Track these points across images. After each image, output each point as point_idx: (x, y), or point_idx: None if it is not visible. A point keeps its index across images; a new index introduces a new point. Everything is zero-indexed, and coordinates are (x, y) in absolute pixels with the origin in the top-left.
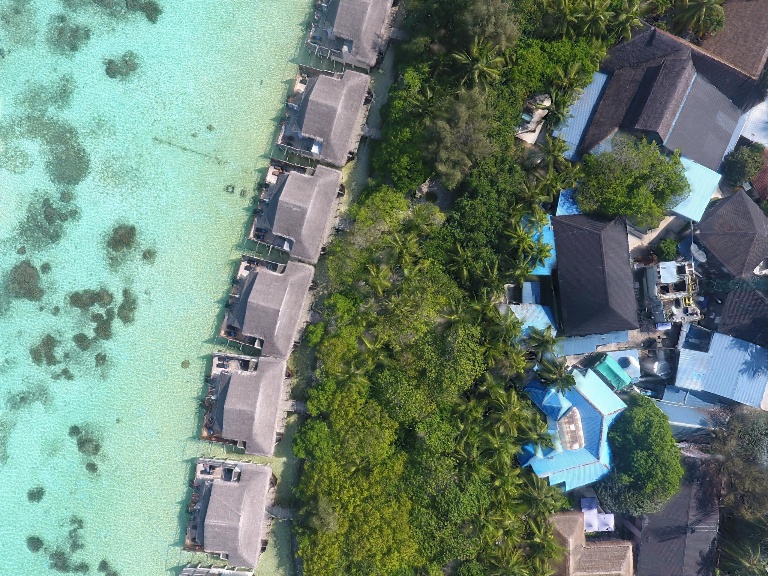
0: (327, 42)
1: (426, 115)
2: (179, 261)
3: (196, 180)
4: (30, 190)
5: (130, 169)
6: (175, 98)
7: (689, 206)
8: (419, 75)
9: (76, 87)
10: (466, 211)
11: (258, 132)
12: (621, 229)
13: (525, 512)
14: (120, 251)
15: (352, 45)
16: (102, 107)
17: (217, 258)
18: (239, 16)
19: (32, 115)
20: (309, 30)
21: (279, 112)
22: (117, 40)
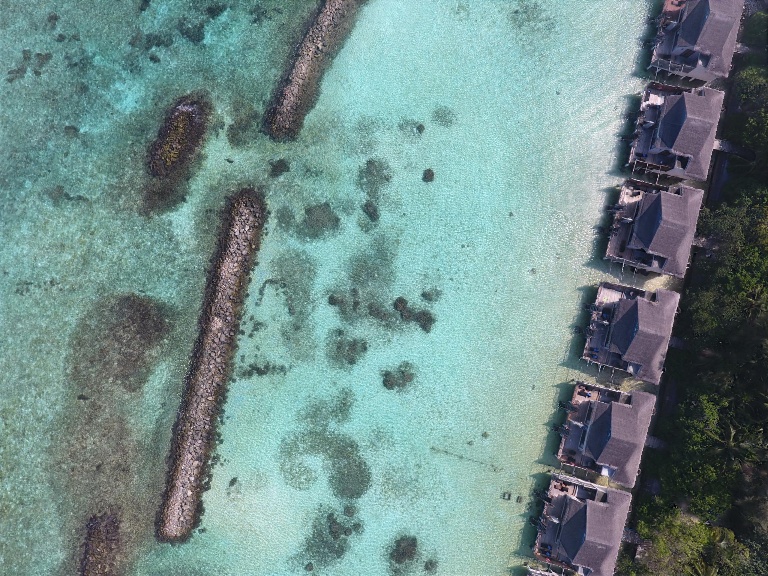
0: (603, 352)
1: (736, 461)
2: (460, 571)
3: (473, 488)
4: (315, 506)
5: (409, 480)
6: (450, 407)
7: None
8: (715, 406)
9: (355, 400)
10: (767, 544)
11: (532, 438)
12: None
13: None
14: (403, 563)
15: (639, 367)
16: (381, 419)
17: (496, 566)
18: (509, 321)
19: (314, 430)
20: (579, 334)
21: (551, 416)
22: (393, 351)
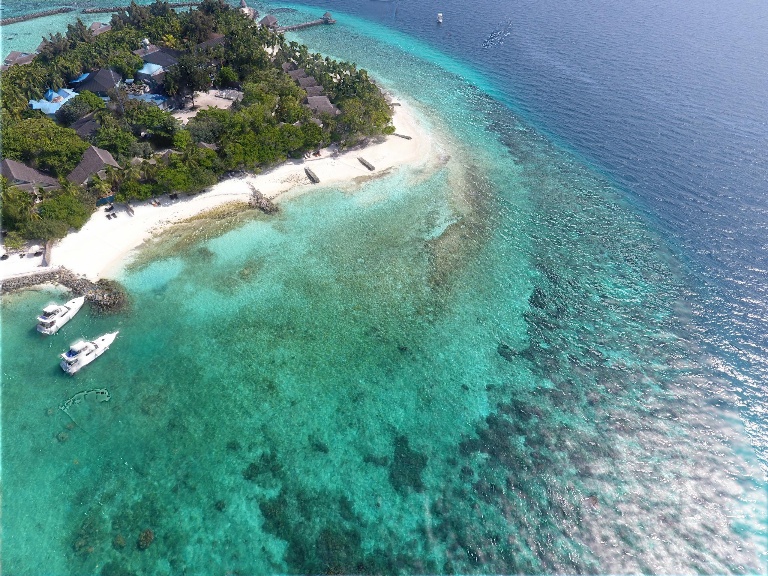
0: None
1: None
2: None
3: None
4: None
5: None
6: None
7: (147, 71)
8: None
9: None
10: None
11: None
12: (117, 74)
13: (5, 96)
14: None
15: None
16: None
17: None
18: None
19: None
20: None
21: None
22: None
